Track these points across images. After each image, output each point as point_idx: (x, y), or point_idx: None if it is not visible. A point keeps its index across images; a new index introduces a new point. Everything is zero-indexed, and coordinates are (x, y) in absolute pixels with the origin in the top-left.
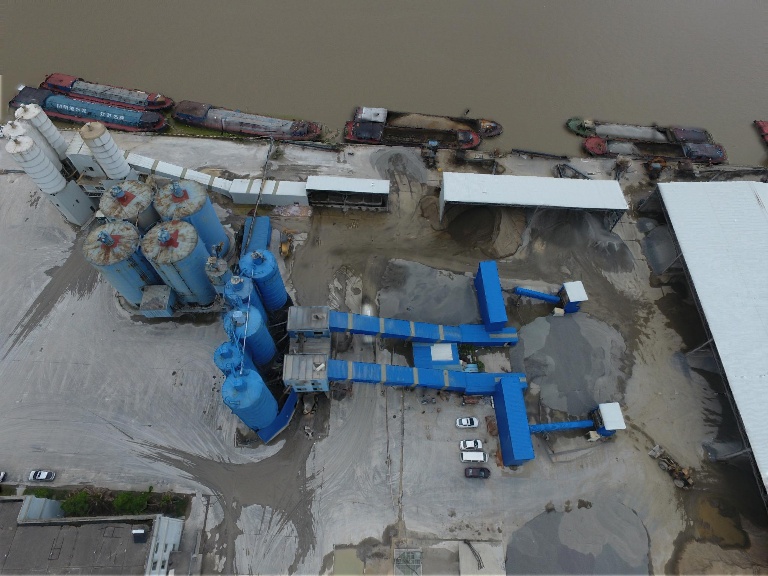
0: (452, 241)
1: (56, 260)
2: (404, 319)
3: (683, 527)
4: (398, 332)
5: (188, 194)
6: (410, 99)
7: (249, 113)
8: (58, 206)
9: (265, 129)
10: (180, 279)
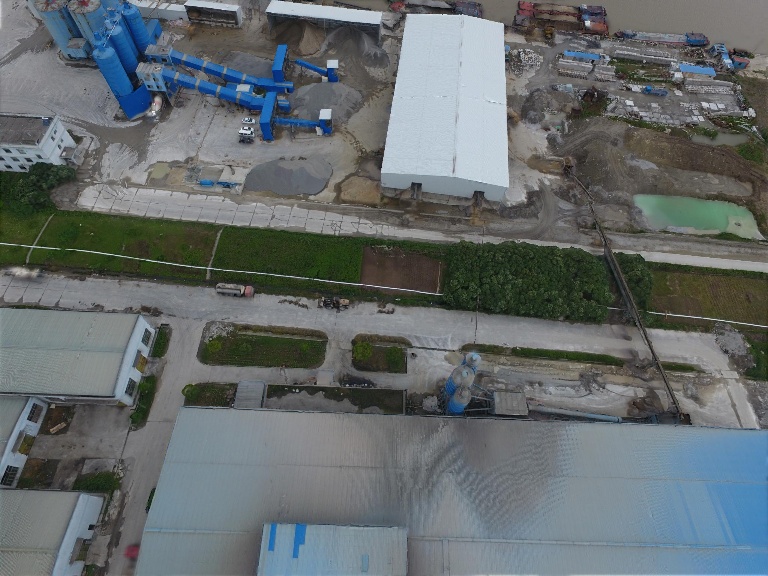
0: (276, 46)
1: (24, 35)
2: None
3: (354, 171)
4: (215, 69)
5: None
6: None
7: None
8: (27, 1)
9: None
10: (90, 30)
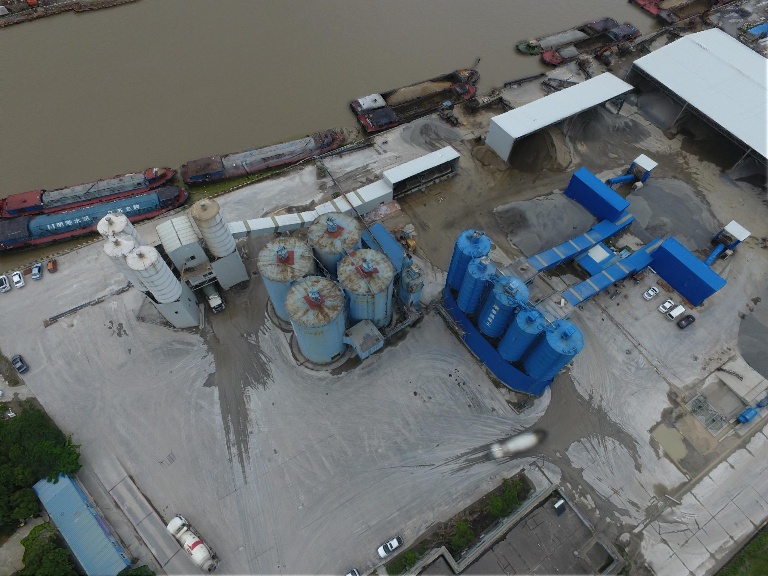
0: (522, 173)
1: (204, 369)
2: (549, 246)
3: None
4: (571, 252)
5: (339, 225)
6: (386, 78)
7: (260, 148)
8: (177, 313)
9: (291, 155)
10: (384, 304)
